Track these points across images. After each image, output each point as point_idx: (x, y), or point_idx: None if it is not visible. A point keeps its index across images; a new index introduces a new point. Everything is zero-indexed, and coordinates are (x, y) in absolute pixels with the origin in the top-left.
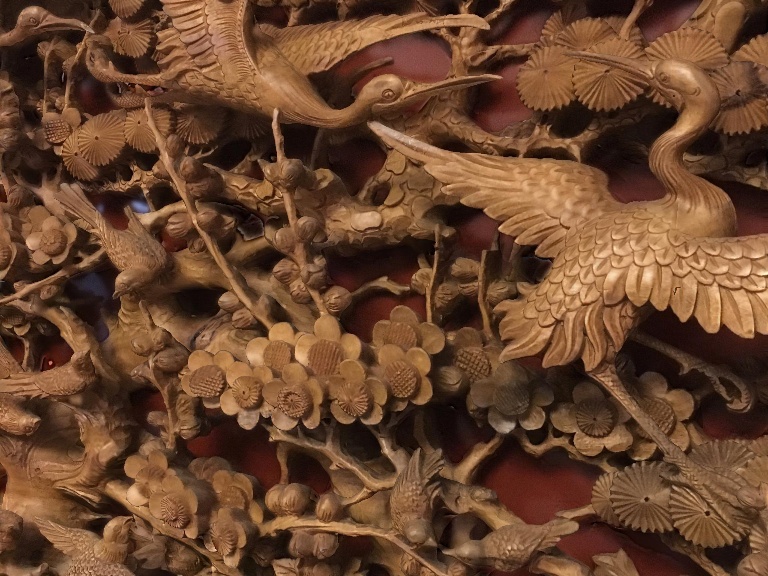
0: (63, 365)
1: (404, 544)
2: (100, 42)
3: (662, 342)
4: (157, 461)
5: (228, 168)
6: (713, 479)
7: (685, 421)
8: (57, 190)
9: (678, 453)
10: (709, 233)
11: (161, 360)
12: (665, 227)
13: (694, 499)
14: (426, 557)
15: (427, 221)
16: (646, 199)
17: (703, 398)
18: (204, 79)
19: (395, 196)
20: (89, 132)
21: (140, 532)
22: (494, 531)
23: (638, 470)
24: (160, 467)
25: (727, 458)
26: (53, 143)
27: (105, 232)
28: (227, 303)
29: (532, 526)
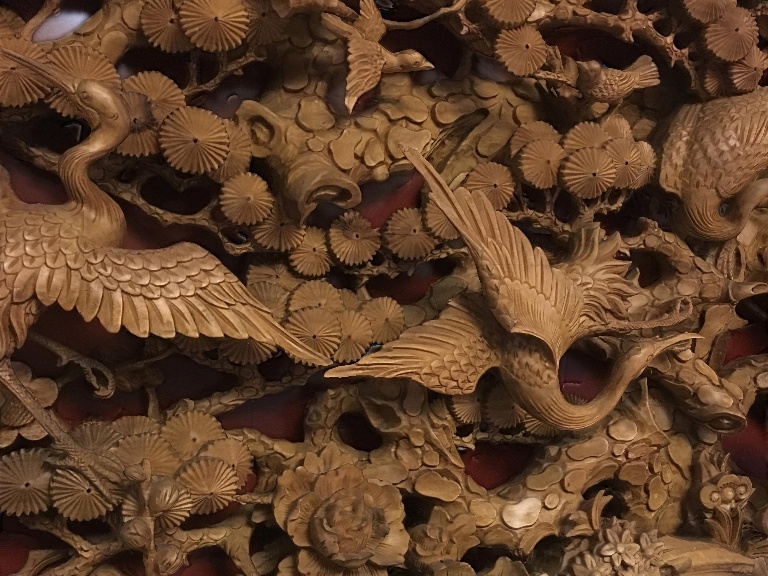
0: None
1: None
2: None
3: (44, 336)
4: None
5: None
6: (96, 460)
7: (48, 408)
8: None
9: (68, 440)
10: (109, 242)
11: None
12: (75, 233)
13: (77, 479)
14: None
15: None
16: (40, 200)
17: (64, 385)
18: None
19: None
20: None
21: None
22: None
23: (17, 458)
24: None
25: (98, 440)
26: None
27: None
28: None
29: None
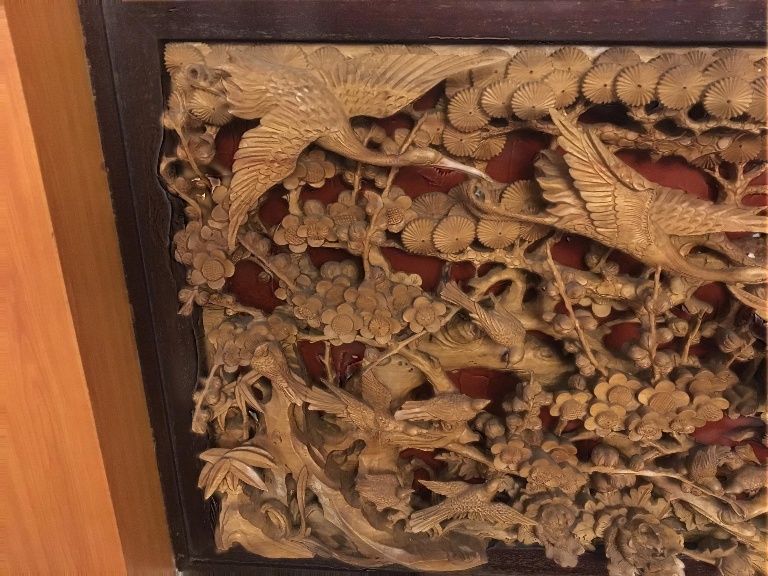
0: (381, 365)
1: (687, 480)
2: (428, 141)
3: None
4: (515, 444)
5: (536, 245)
6: None
7: None
8: (378, 250)
9: None
10: None
11: (541, 402)
12: None
13: None
14: (699, 485)
15: (697, 303)
16: None
17: None
18: (595, 232)
19: (680, 288)
20: (448, 233)
21: (453, 458)
22: (742, 475)
23: None
24: (516, 447)
25: None
26: (390, 224)
27: (487, 319)
28: (585, 365)
29: (764, 472)
